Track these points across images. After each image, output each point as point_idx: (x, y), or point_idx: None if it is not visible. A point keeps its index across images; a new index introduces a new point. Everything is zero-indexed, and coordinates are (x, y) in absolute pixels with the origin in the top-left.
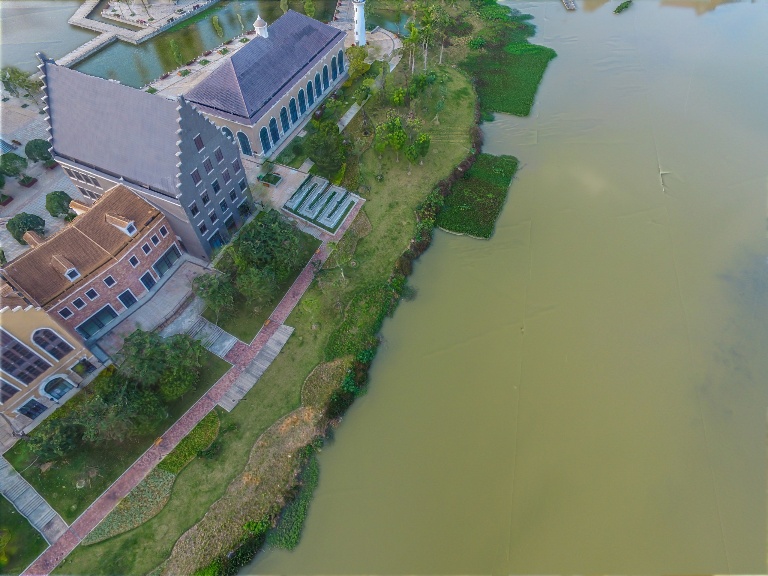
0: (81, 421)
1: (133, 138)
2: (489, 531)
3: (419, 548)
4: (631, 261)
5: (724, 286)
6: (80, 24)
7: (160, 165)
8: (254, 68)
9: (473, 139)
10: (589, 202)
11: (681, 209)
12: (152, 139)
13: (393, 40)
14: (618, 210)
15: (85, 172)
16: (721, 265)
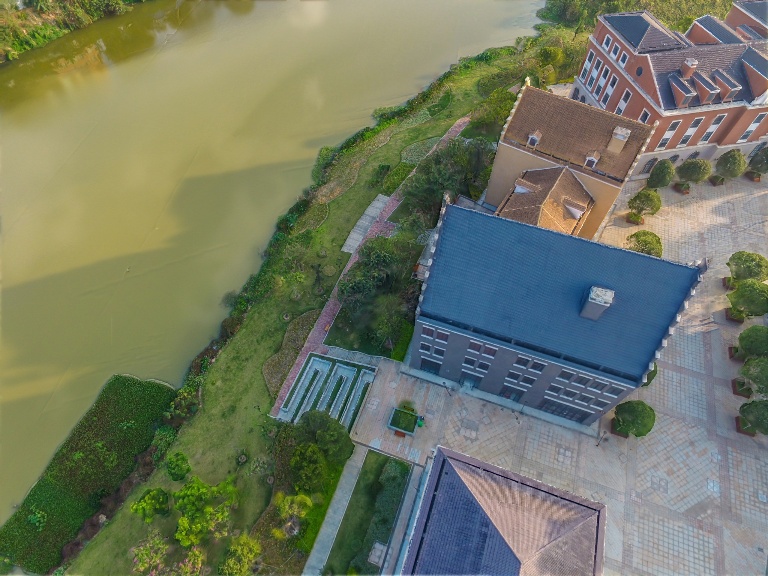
0: (457, 140)
1: None
2: (207, 157)
3: (251, 151)
4: None
5: None
6: None
7: None
8: None
9: None
10: None
11: None
12: None
13: None
14: None
15: None
16: None
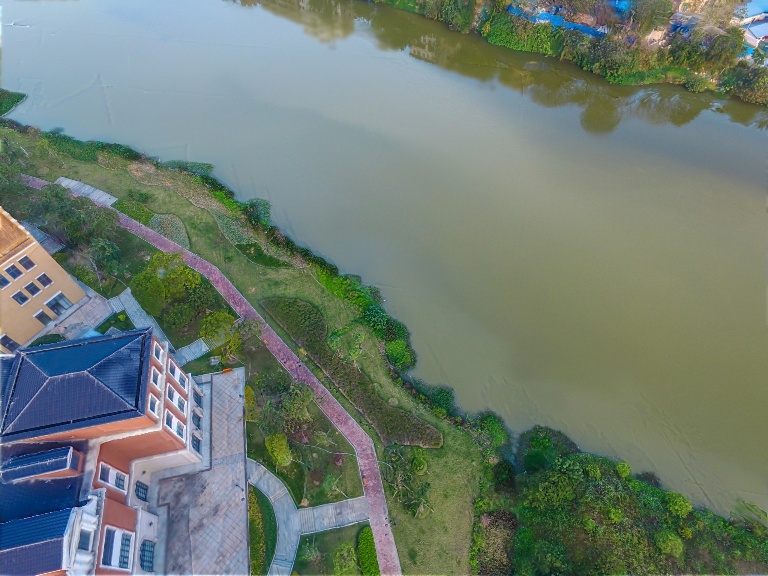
0: None
1: None
2: (219, 102)
3: (222, 124)
4: (79, 46)
5: (113, 21)
6: None
7: None
8: None
9: None
10: (20, 54)
11: (49, 24)
12: None
13: None
14: (35, 44)
15: None
16: (99, 19)
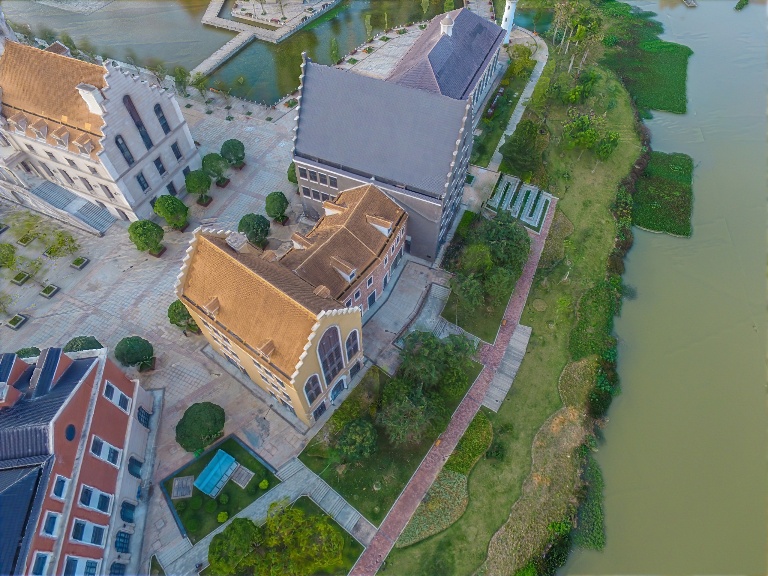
0: (394, 423)
1: (399, 138)
2: None
3: (727, 548)
4: None
5: None
6: (215, 23)
7: (426, 165)
8: (446, 67)
9: (642, 137)
10: None
11: None
12: (423, 138)
13: (534, 38)
14: None
15: (327, 172)
16: None
